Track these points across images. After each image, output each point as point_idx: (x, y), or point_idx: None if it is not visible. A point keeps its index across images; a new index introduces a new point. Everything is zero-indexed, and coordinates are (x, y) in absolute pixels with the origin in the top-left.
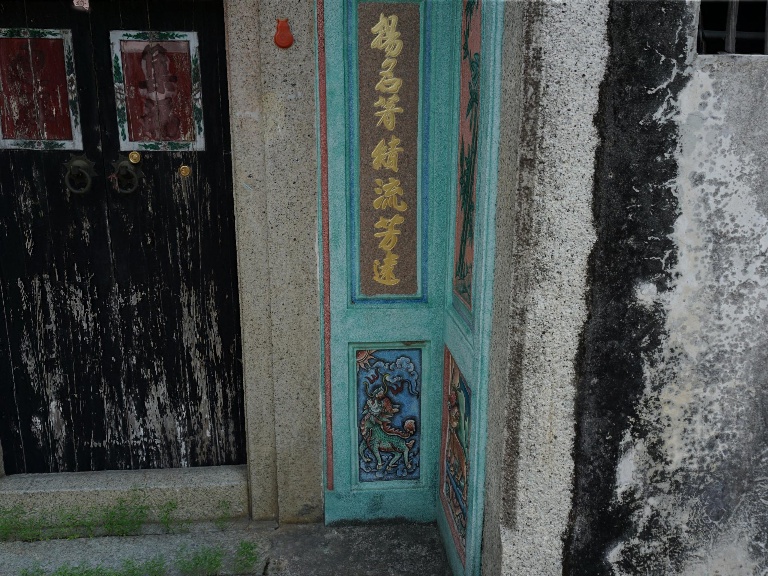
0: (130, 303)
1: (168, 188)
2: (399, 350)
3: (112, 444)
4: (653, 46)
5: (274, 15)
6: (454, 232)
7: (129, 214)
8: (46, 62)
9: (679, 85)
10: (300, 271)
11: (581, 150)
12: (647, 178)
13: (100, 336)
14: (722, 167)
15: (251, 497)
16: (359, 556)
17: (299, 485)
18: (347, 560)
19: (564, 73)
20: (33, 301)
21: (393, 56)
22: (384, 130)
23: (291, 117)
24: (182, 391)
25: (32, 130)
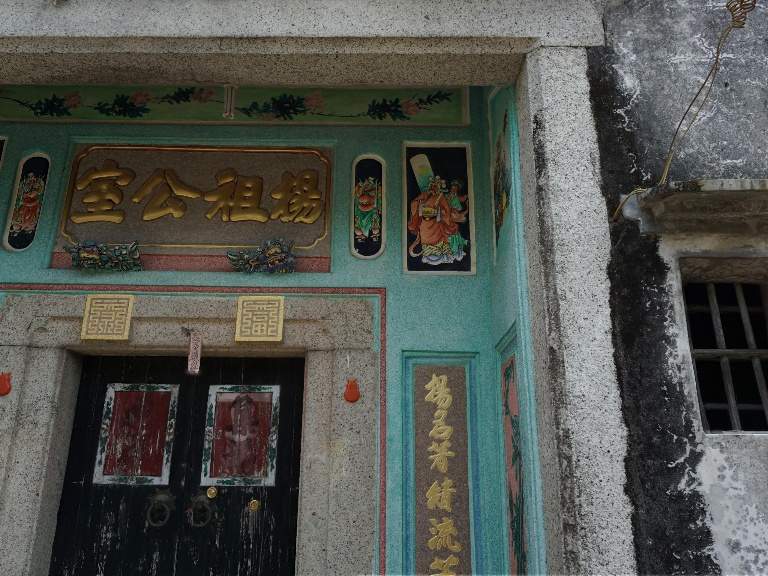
0: None
1: (237, 522)
2: None
3: None
4: (664, 427)
5: (345, 376)
6: None
7: (197, 547)
8: (154, 410)
9: (695, 460)
10: None
11: (618, 517)
12: (685, 545)
13: None
14: (755, 535)
15: None
16: None
17: None
18: None
19: (591, 449)
20: None
21: (444, 408)
22: (437, 472)
23: (354, 460)
24: None
25: (129, 467)
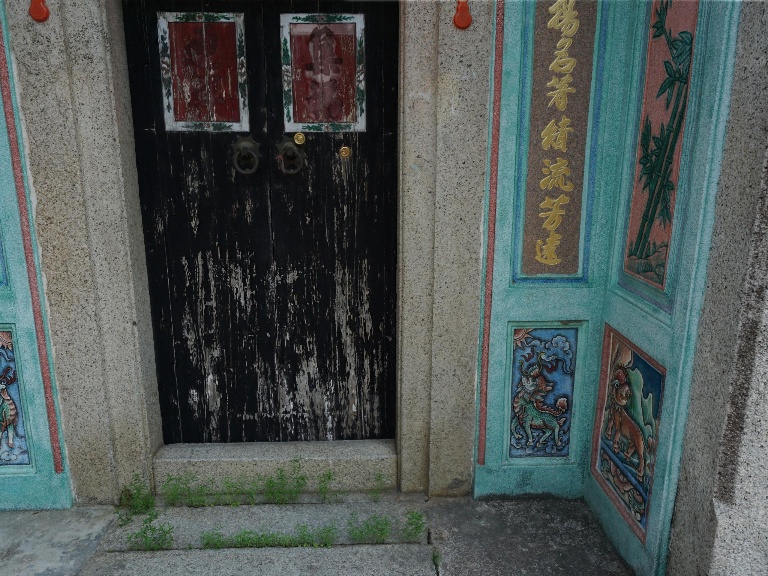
0: (287, 281)
1: (328, 169)
2: (556, 329)
3: (263, 417)
4: None
5: None
6: (624, 212)
7: (290, 194)
8: (219, 45)
9: None
10: (464, 250)
11: None
12: None
13: (257, 313)
14: None
15: (401, 470)
16: (516, 529)
17: (450, 459)
18: (506, 532)
19: None
20: (196, 278)
21: (569, 36)
22: (555, 110)
23: (465, 98)
24: (331, 367)
25: (202, 112)
